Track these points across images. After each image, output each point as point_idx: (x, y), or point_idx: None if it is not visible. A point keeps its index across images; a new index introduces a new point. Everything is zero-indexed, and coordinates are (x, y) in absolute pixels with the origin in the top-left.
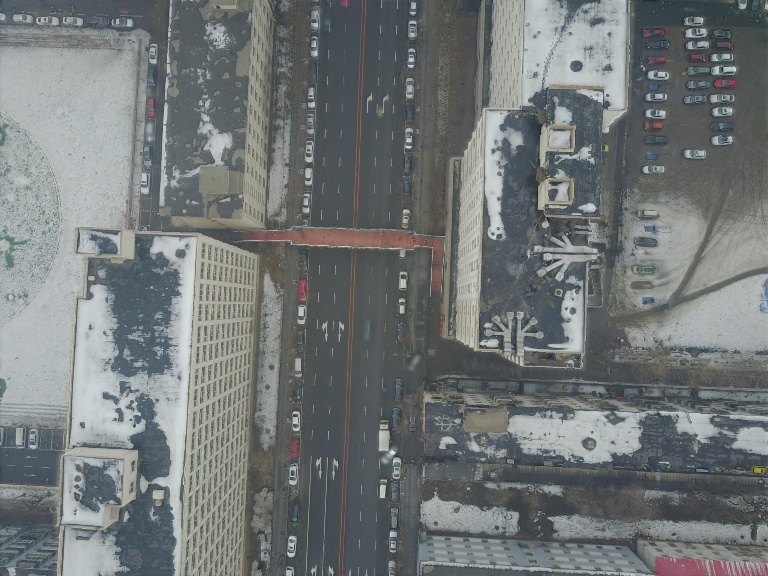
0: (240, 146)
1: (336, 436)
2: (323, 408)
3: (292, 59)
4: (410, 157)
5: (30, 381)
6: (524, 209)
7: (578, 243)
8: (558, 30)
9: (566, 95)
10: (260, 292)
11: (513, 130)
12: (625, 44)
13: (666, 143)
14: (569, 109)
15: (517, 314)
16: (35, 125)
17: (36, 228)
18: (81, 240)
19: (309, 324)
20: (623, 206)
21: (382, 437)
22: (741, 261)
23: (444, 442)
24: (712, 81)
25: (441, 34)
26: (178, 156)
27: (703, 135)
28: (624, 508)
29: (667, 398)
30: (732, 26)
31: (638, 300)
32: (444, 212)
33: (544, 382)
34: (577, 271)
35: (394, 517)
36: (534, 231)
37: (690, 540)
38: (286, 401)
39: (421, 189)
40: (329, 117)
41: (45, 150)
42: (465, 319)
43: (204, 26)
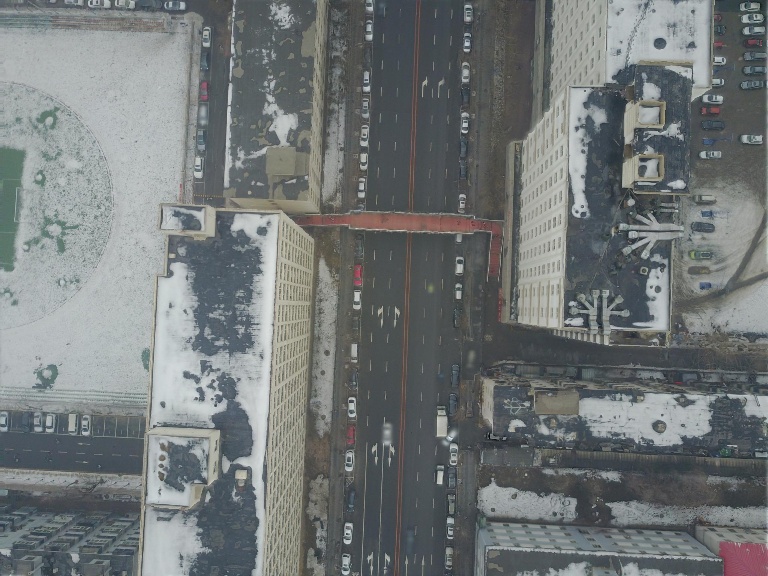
0: (306, 127)
1: (392, 422)
2: (379, 394)
3: (347, 43)
4: (466, 142)
5: (82, 367)
6: (608, 187)
7: (663, 221)
8: (642, 7)
9: (655, 71)
10: (315, 277)
11: (597, 108)
12: (709, 22)
13: (723, 128)
14: (658, 85)
15: (603, 292)
16: (86, 109)
17: (88, 213)
18: (164, 216)
19: (364, 309)
20: None
21: (440, 423)
22: None
23: (513, 425)
24: None
25: (497, 19)
26: (243, 137)
27: (760, 120)
28: (688, 492)
29: (725, 383)
30: None
31: (695, 285)
32: (504, 196)
33: (601, 368)
34: (662, 249)
35: (452, 503)
36: (618, 209)
37: (748, 526)
38: (341, 387)
39: (477, 174)
40: (384, 102)
41: (97, 134)
42: (538, 300)
43: (269, 6)
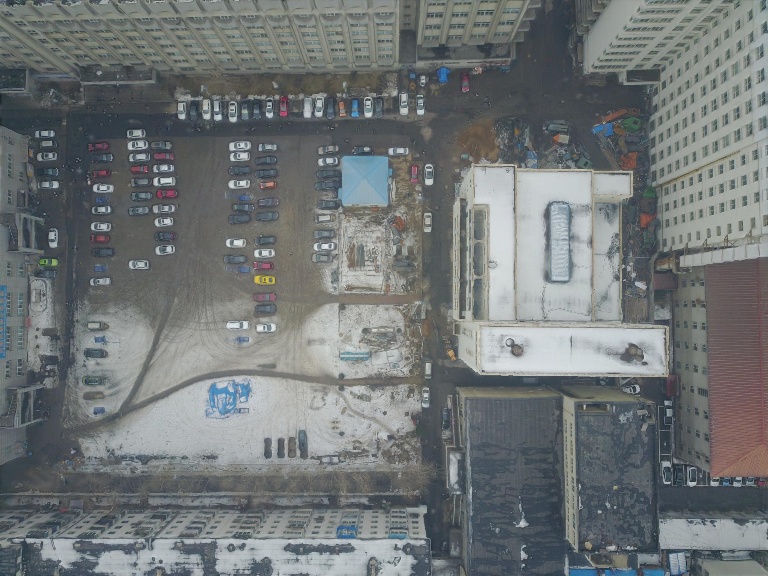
0: None
1: None
2: None
3: None
4: None
5: None
6: None
7: None
8: None
9: None
10: None
11: None
12: None
13: (112, 255)
14: None
15: None
16: None
17: None
18: None
19: None
20: (74, 318)
21: None
22: (187, 368)
23: None
24: (156, 191)
25: None
26: None
27: (149, 245)
28: None
29: (116, 507)
30: (174, 136)
31: (90, 410)
32: None
33: (2, 496)
34: None
35: None
36: None
37: None
38: None
39: None
40: None
41: None
42: None
43: None
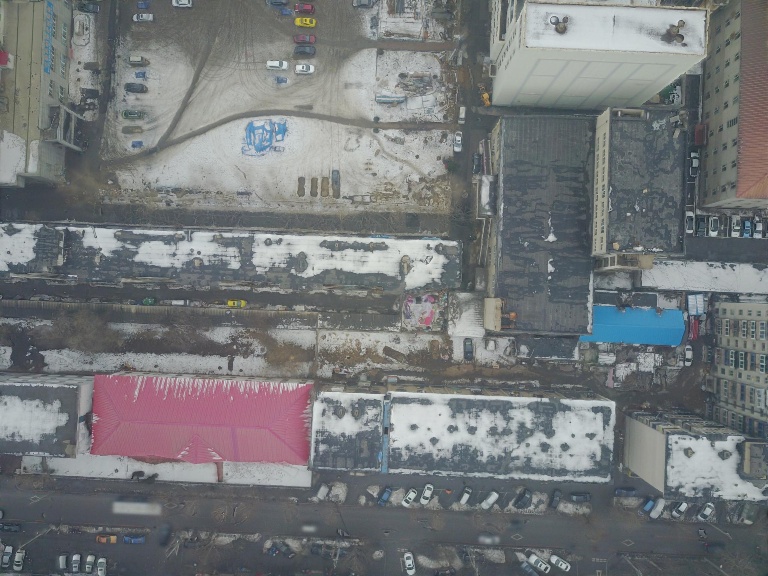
0: None
1: None
2: None
3: None
4: None
5: None
6: None
7: None
8: None
9: None
10: None
11: None
12: None
13: None
14: None
15: None
16: None
17: None
18: None
19: None
20: (116, 54)
21: None
22: (225, 106)
23: None
24: None
25: None
26: None
27: None
28: (67, 329)
29: None
30: None
31: (128, 144)
32: None
33: (39, 223)
34: None
35: None
36: None
37: (171, 371)
38: None
39: None
40: None
41: None
42: None
43: None
